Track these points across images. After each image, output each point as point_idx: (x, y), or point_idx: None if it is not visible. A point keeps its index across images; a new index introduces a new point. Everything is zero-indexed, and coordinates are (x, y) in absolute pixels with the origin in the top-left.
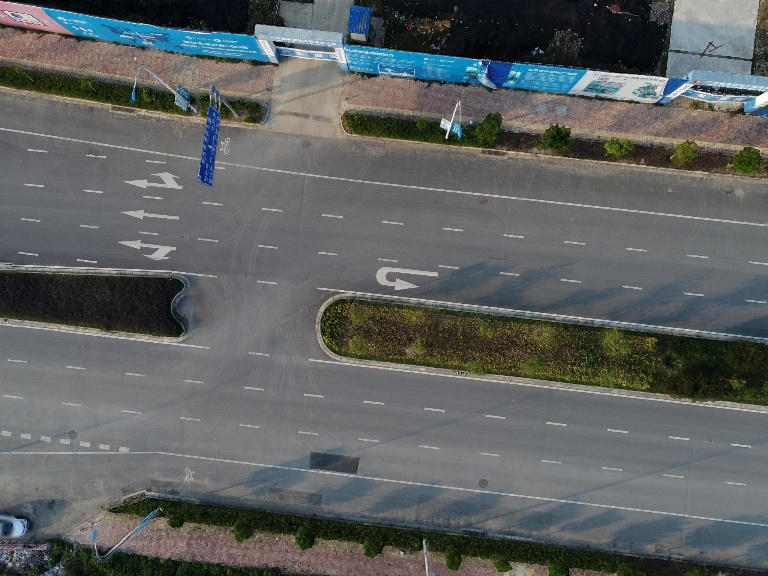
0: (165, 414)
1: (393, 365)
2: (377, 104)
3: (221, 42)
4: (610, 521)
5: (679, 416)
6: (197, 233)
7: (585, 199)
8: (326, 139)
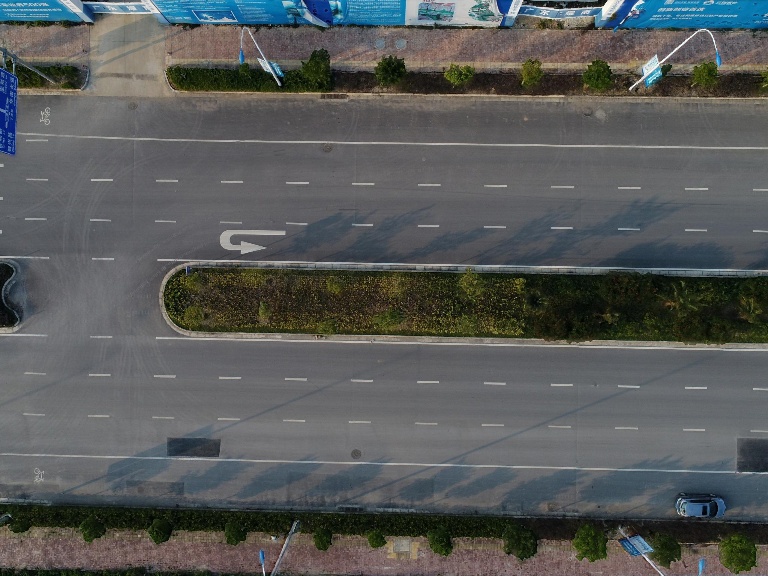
0: (6, 412)
1: (247, 335)
2: (203, 56)
3: (16, 0)
4: (497, 482)
5: (559, 361)
6: (23, 213)
7: (436, 137)
8: (153, 99)
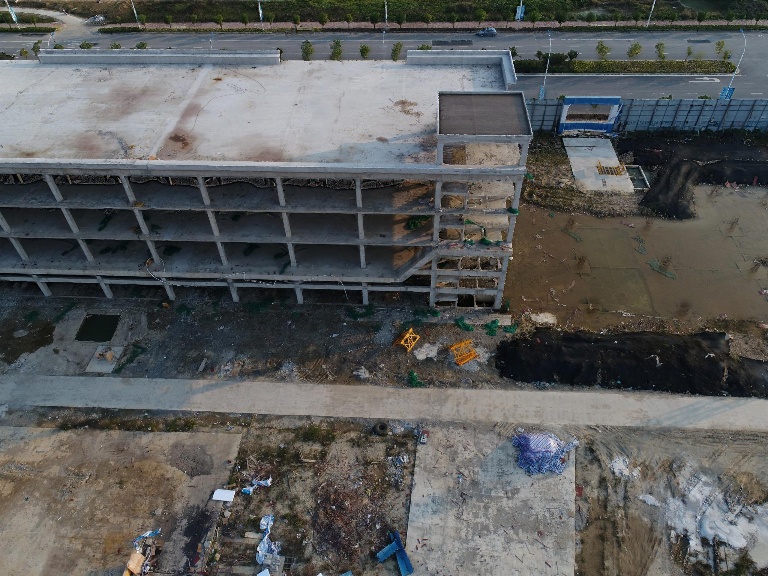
0: None
1: None
2: None
3: None
4: (568, 37)
5: None
6: None
7: None
8: None
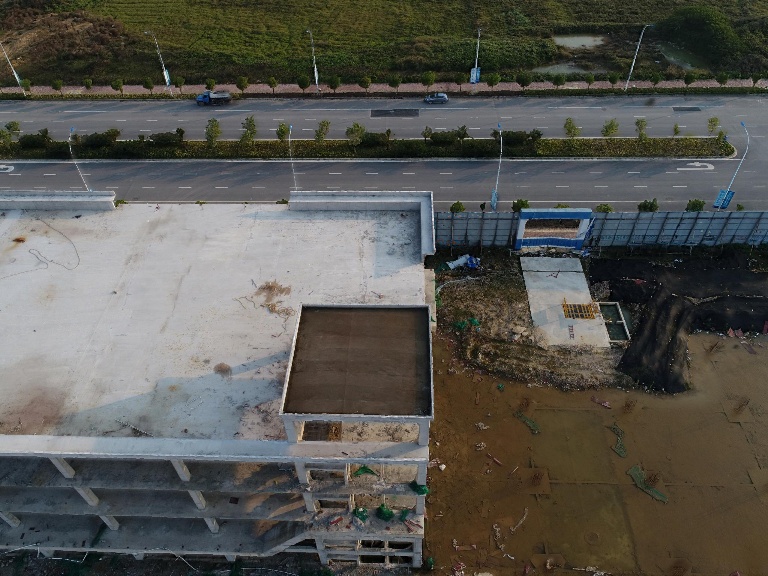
0: None
1: None
2: None
3: None
4: (533, 104)
5: None
6: None
7: None
8: None
